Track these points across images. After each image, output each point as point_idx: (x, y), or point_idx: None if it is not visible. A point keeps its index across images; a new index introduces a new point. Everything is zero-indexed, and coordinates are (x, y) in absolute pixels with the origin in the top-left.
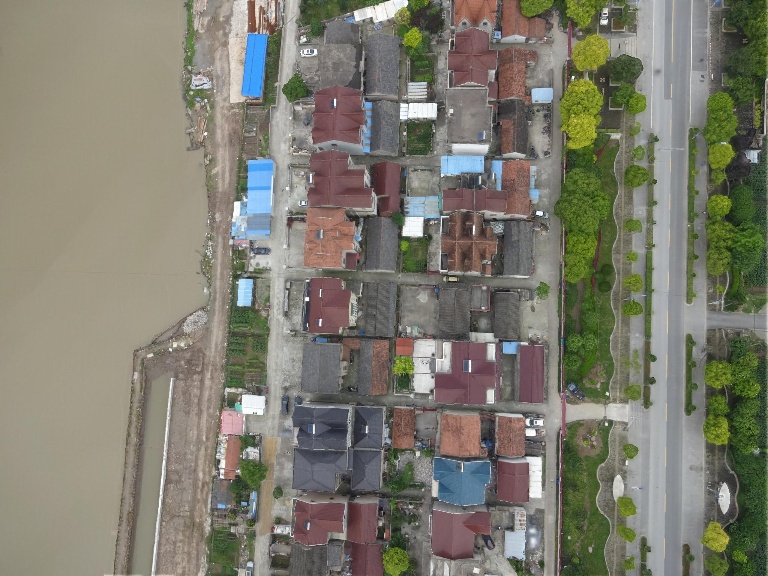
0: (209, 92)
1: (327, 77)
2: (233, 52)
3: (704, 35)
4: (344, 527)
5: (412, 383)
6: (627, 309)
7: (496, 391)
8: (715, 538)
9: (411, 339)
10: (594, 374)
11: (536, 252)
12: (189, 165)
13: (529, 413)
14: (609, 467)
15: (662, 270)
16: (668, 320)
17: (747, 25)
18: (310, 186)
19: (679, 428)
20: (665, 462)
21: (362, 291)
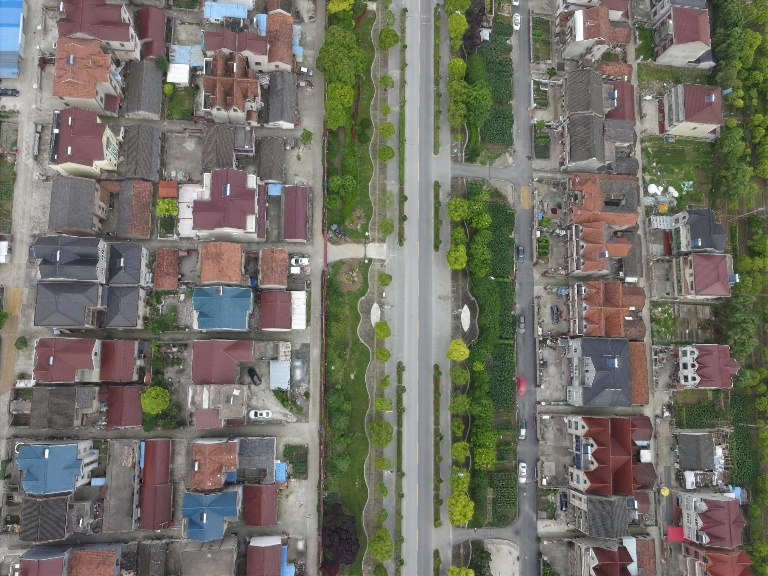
0: None
1: None
2: None
3: None
4: (96, 365)
5: (177, 228)
6: (381, 152)
7: (261, 229)
8: (457, 349)
9: (175, 182)
10: (355, 216)
11: (301, 106)
12: None
13: (295, 254)
14: (369, 300)
15: (413, 126)
16: (419, 169)
17: None
18: (61, 16)
19: (429, 263)
20: (418, 293)
21: (124, 136)
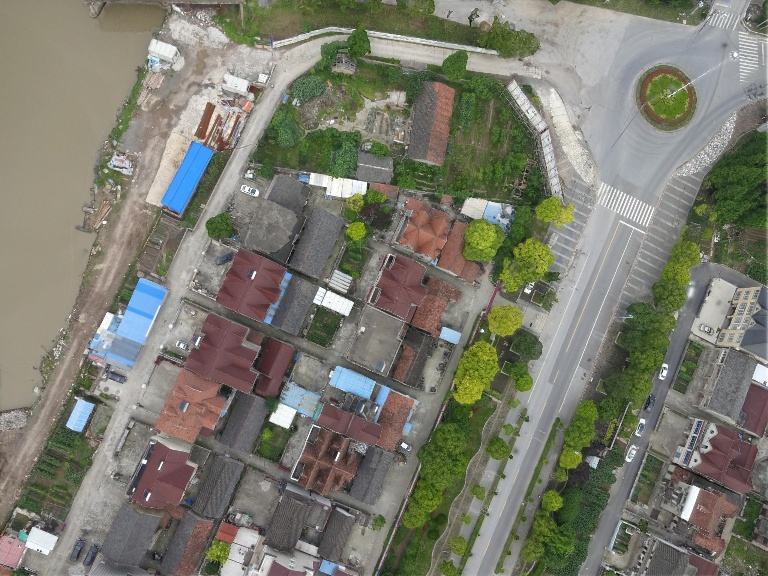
0: (126, 179)
1: (257, 235)
2: (170, 149)
3: (600, 339)
4: None
5: (221, 568)
6: (443, 570)
7: None
8: None
9: (237, 527)
10: None
11: (387, 479)
12: (72, 246)
13: None
14: None
15: (486, 536)
16: None
17: (634, 354)
18: (194, 346)
19: None
20: None
21: (207, 458)
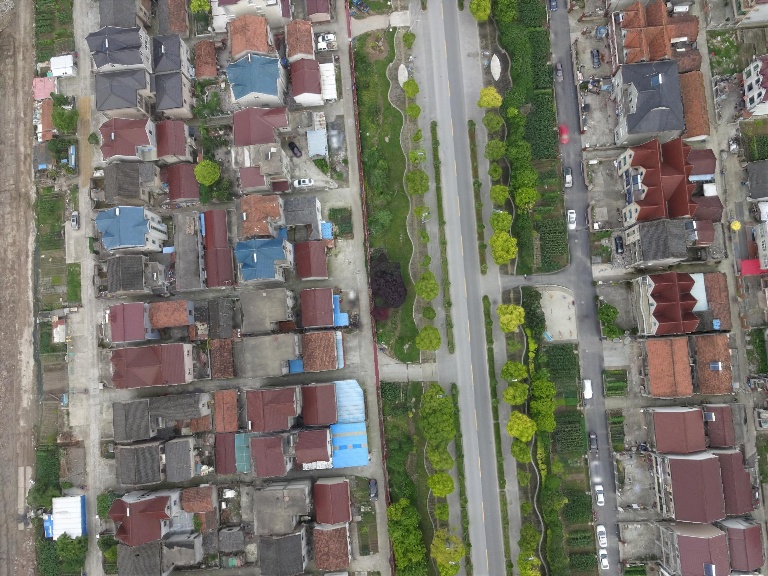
0: None
1: None
2: None
3: None
4: (152, 142)
5: (212, 25)
6: None
7: (285, 9)
8: (486, 94)
9: None
10: None
11: None
12: None
13: None
14: (397, 67)
15: None
16: None
17: None
18: None
19: (455, 22)
20: (445, 54)
21: None
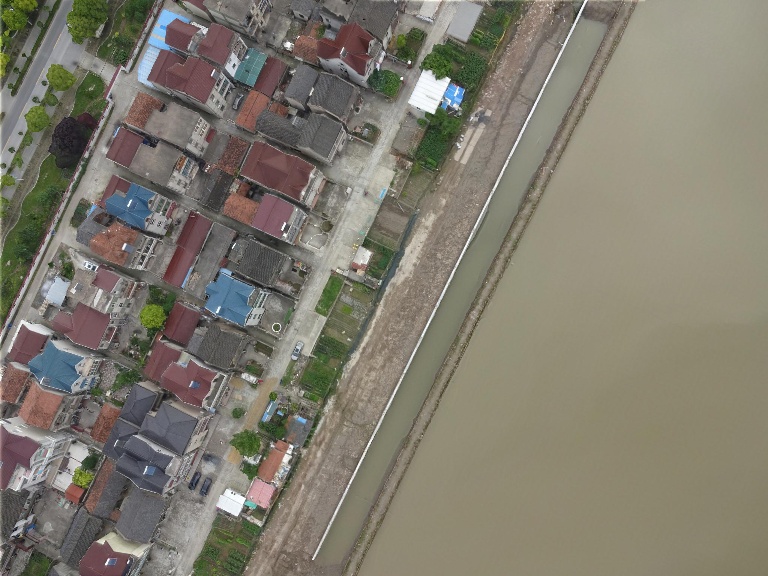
0: None
1: None
2: None
3: None
4: None
5: None
6: None
7: None
8: None
9: None
10: None
11: None
12: None
13: None
14: None
15: None
16: None
17: None
18: None
19: None
20: None
21: None
